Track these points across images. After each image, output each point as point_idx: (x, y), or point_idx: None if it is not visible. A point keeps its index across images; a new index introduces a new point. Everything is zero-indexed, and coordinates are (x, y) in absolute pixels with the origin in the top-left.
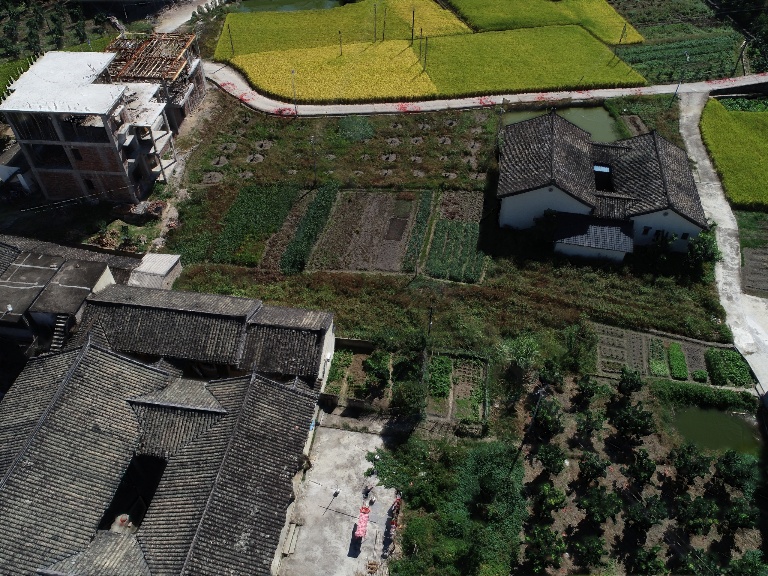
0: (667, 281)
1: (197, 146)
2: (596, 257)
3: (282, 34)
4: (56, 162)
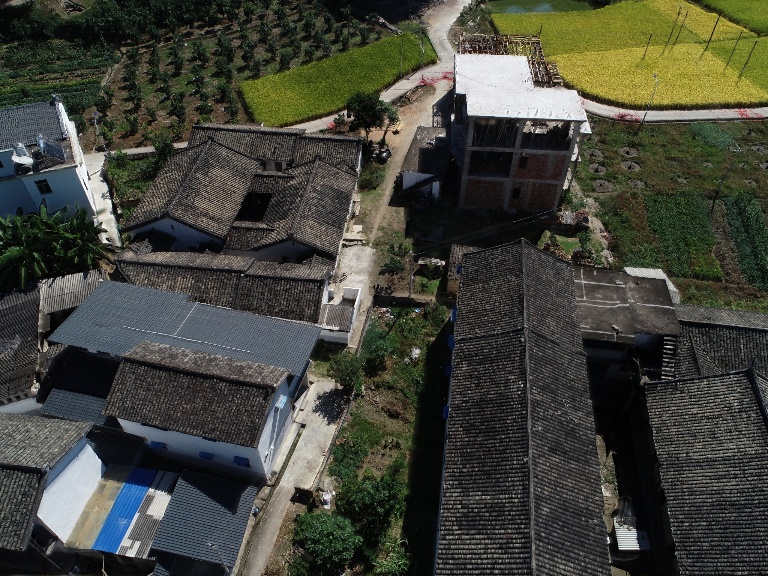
0: None
1: None
2: None
3: (566, 36)
4: (487, 170)
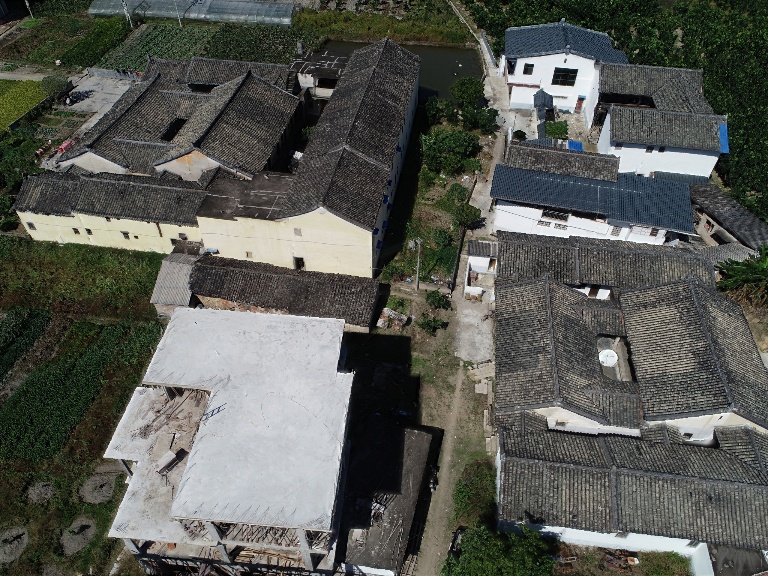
0: None
1: (110, 575)
2: None
3: None
4: None
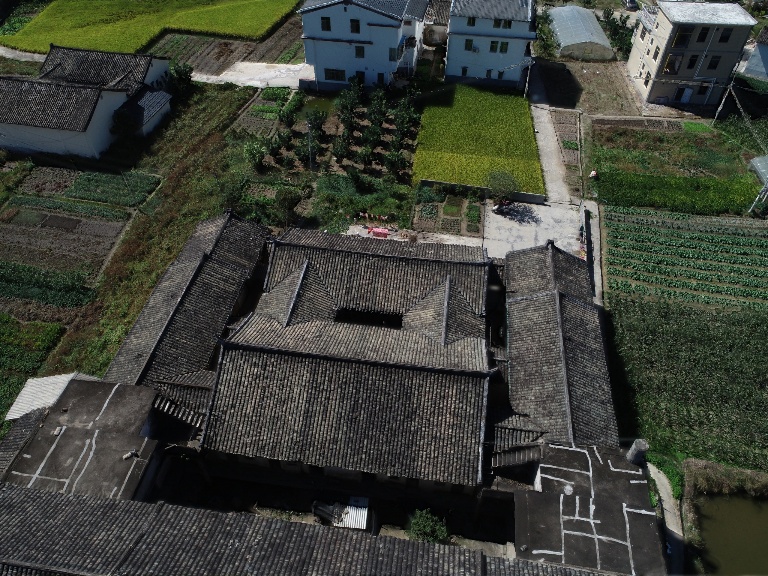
0: (199, 97)
1: None
2: (161, 119)
3: None
4: None
